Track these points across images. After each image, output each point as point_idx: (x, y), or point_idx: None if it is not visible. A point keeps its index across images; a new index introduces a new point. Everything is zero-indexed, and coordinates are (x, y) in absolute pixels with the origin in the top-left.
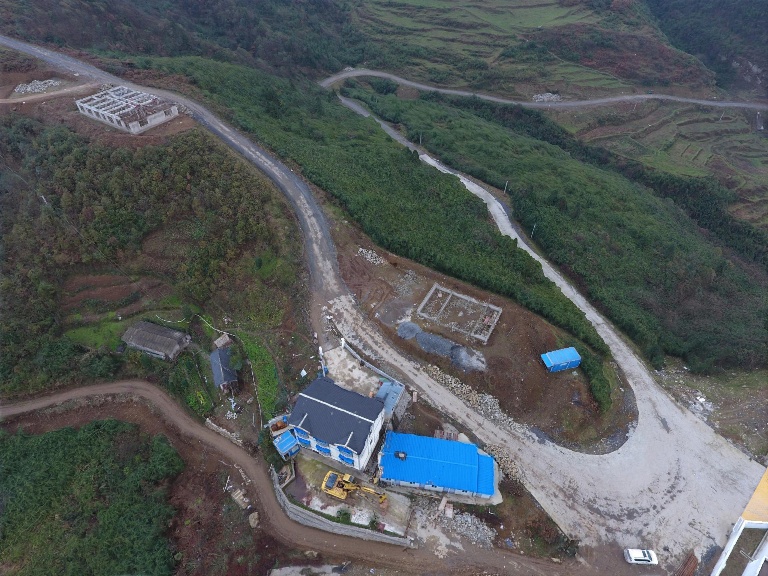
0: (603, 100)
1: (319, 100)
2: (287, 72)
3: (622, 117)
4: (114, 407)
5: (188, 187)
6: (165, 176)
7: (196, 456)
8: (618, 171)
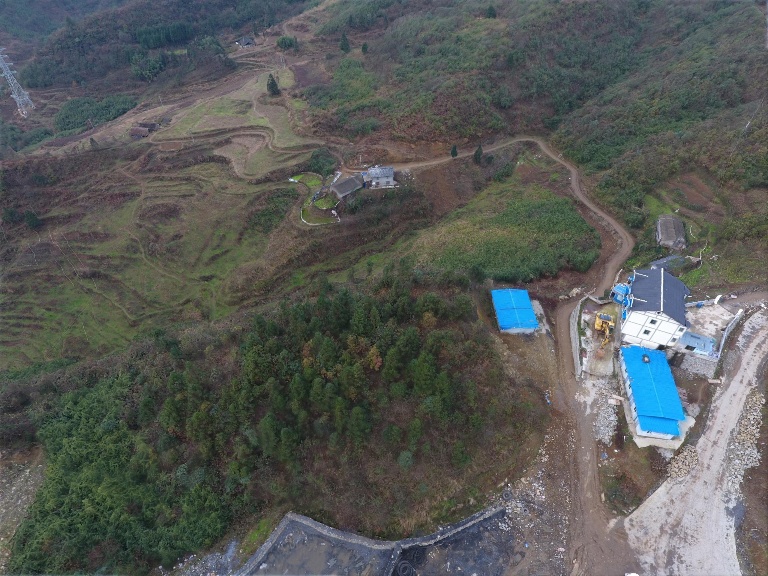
0: None
1: None
2: None
3: None
4: (608, 237)
5: None
6: None
7: (593, 275)
8: None
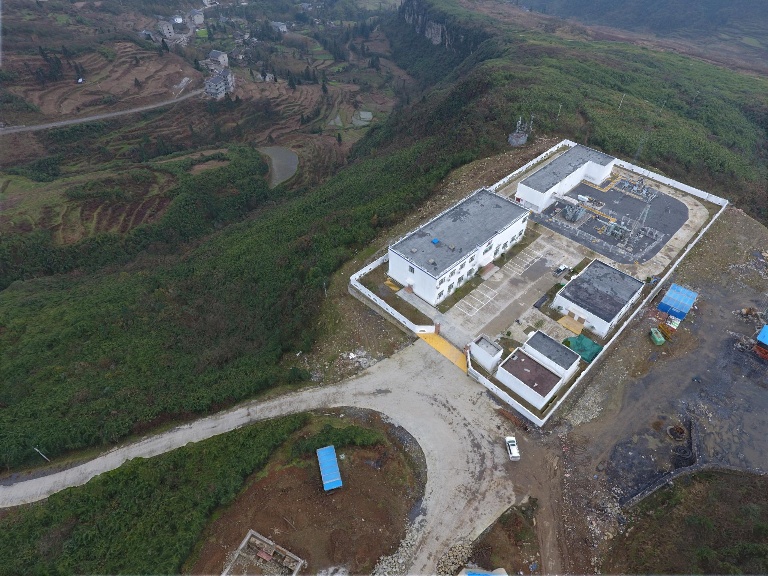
0: None
1: None
2: None
3: None
4: None
5: None
6: None
7: None
8: None
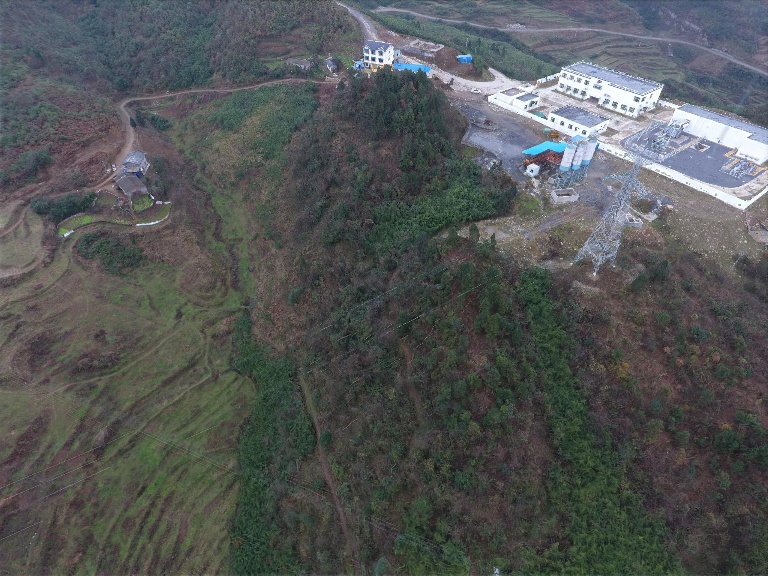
0: (555, 29)
1: None
2: None
3: (566, 39)
4: None
5: (311, 8)
6: (300, 5)
7: (322, 87)
8: None
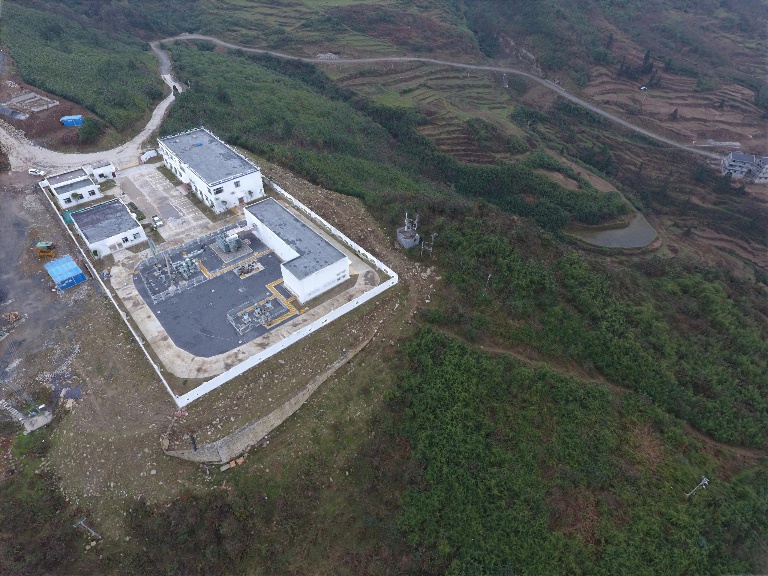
0: (372, 59)
1: (96, 35)
2: (108, 26)
3: (381, 71)
4: None
5: None
6: None
7: None
8: (353, 104)
